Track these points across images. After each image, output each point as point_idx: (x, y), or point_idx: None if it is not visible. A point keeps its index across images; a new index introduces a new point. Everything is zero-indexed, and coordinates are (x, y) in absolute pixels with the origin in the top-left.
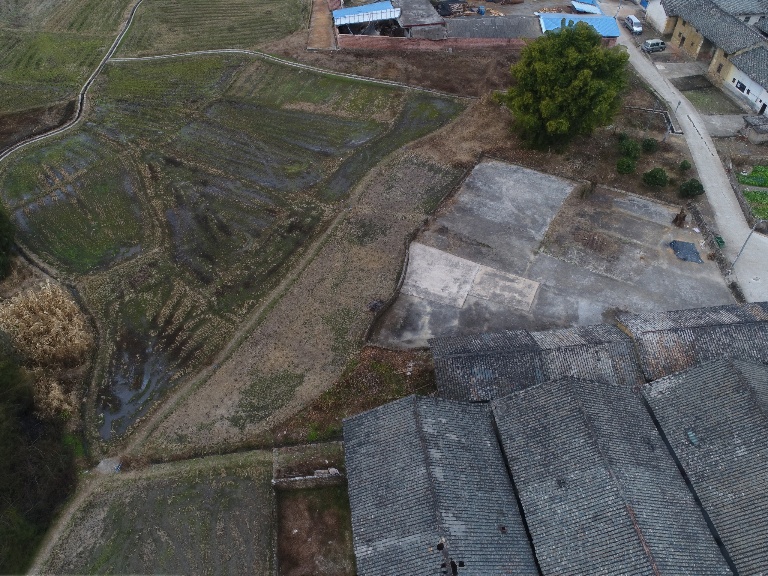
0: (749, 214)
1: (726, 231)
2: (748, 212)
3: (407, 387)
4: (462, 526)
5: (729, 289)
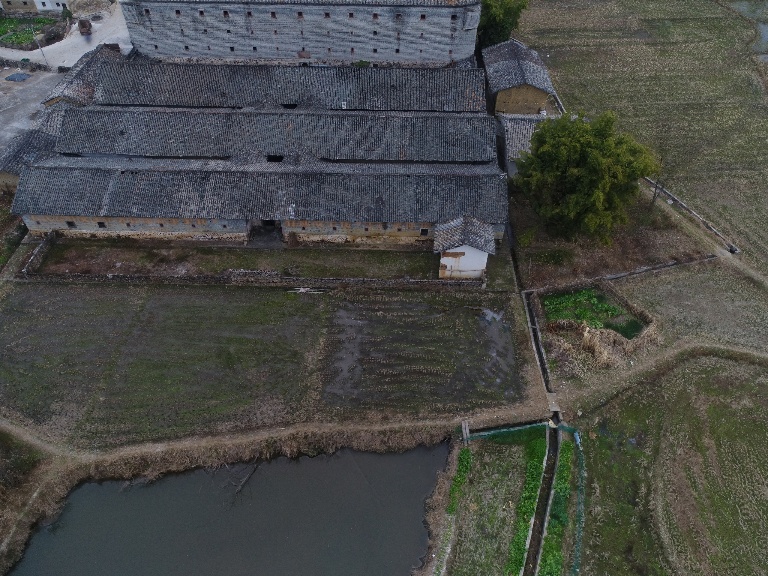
0: (16, 48)
1: (20, 58)
2: (15, 46)
3: (6, 207)
4: (118, 166)
5: (61, 73)
